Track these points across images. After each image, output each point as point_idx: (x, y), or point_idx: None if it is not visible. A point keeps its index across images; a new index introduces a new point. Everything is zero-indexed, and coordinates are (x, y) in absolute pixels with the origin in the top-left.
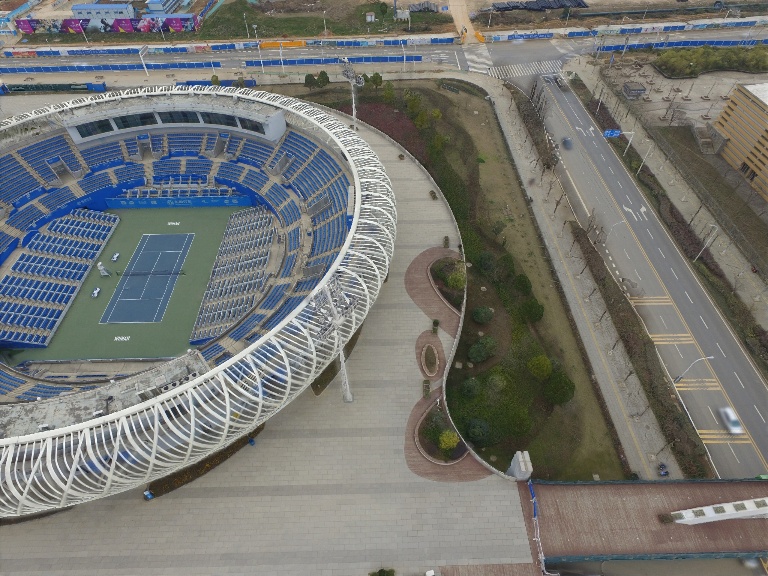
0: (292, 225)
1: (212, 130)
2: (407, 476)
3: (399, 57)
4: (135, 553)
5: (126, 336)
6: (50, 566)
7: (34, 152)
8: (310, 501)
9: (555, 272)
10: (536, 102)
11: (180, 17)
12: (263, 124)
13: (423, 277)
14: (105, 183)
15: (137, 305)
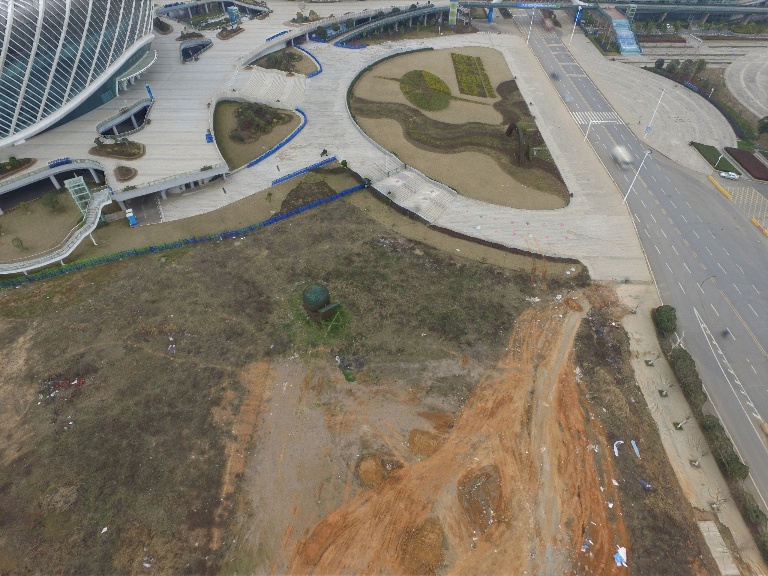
0: None
1: None
2: None
3: None
4: None
5: None
6: (339, 5)
7: None
8: (399, 1)
9: None
10: None
11: None
12: None
13: None
14: None
15: None
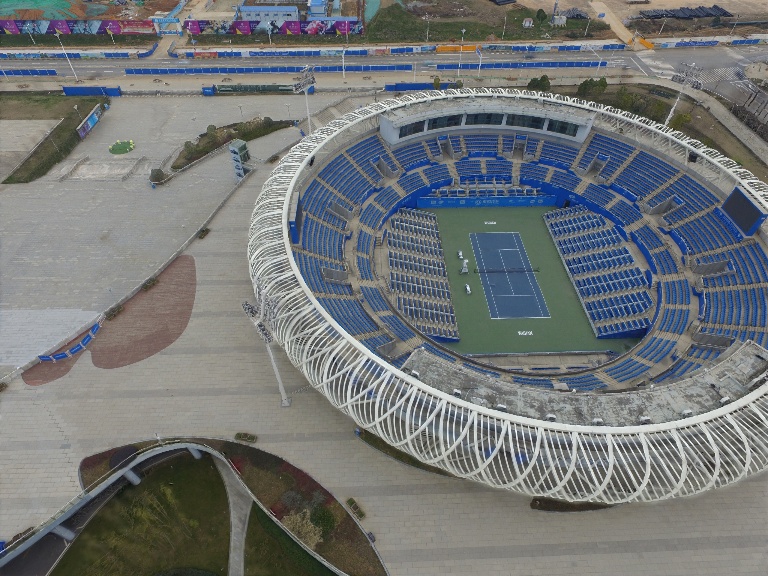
0: (634, 224)
1: (506, 132)
2: None
3: (585, 62)
4: (745, 533)
5: (528, 331)
6: (675, 546)
7: (358, 152)
8: None
9: None
10: (760, 107)
11: (346, 20)
12: (581, 126)
13: None
14: (419, 183)
15: (515, 301)
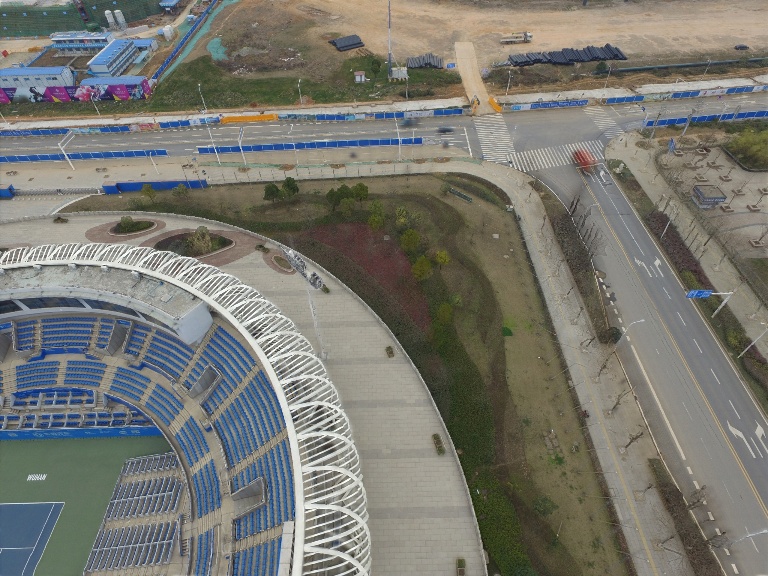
0: (206, 518)
1: None
2: None
3: (393, 140)
4: None
5: None
6: None
7: None
8: None
9: None
10: (579, 224)
11: (127, 82)
12: None
13: None
14: None
15: None
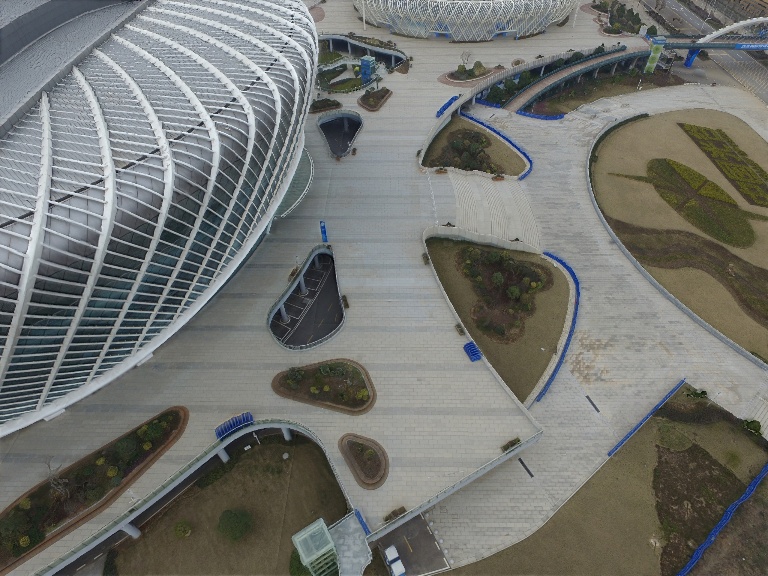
0: None
1: None
2: (602, 37)
3: None
4: None
5: None
6: None
7: None
8: (571, 40)
9: (641, 22)
10: None
11: None
12: None
13: (588, 9)
14: None
15: None
